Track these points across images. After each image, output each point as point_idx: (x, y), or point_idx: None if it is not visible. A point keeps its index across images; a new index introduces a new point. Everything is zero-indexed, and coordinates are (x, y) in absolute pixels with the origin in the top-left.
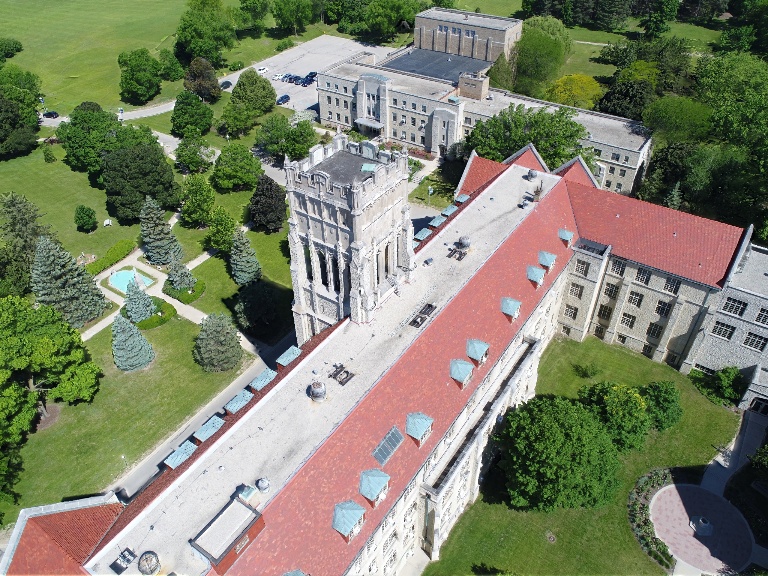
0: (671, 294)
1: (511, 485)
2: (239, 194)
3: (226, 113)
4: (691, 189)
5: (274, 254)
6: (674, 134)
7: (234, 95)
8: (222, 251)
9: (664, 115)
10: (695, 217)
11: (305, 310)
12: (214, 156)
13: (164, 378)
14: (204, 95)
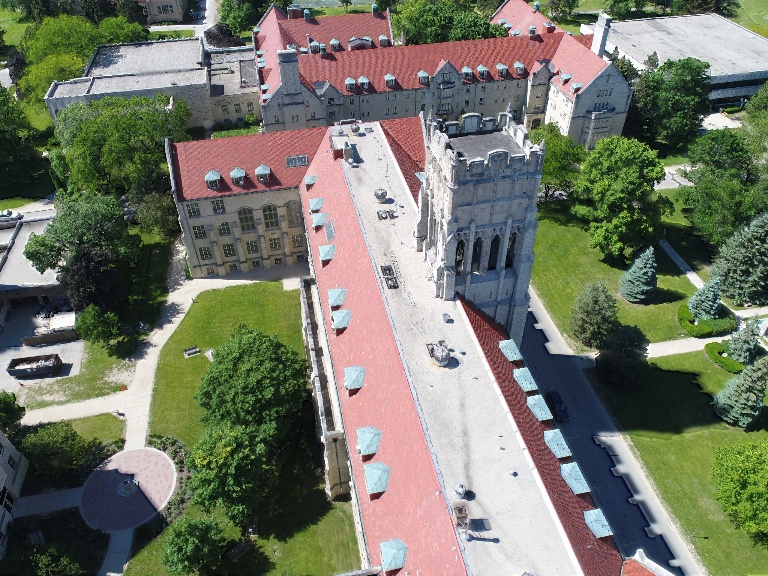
0: None
1: None
2: None
3: None
4: None
5: None
6: None
7: None
8: None
9: None
10: None
11: None
12: None
13: None
14: None
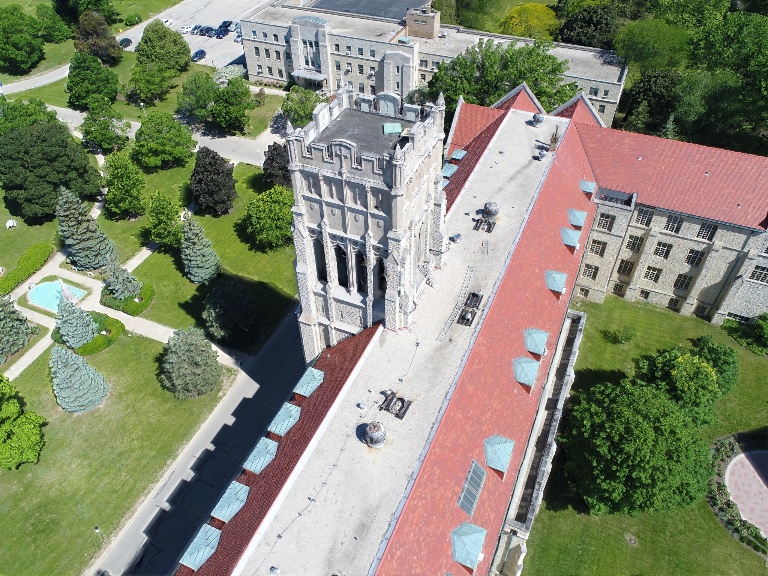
0: (705, 241)
1: (586, 491)
2: (170, 172)
3: (135, 76)
4: (683, 120)
5: (230, 241)
6: (652, 61)
7: (140, 54)
8: (165, 244)
9: (640, 41)
10: (728, 152)
11: (316, 319)
12: (130, 129)
13: (127, 415)
14: (101, 57)
